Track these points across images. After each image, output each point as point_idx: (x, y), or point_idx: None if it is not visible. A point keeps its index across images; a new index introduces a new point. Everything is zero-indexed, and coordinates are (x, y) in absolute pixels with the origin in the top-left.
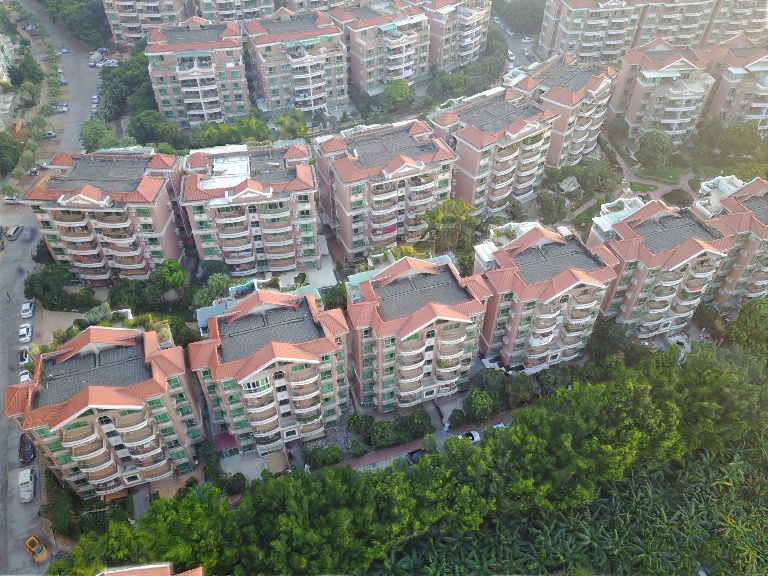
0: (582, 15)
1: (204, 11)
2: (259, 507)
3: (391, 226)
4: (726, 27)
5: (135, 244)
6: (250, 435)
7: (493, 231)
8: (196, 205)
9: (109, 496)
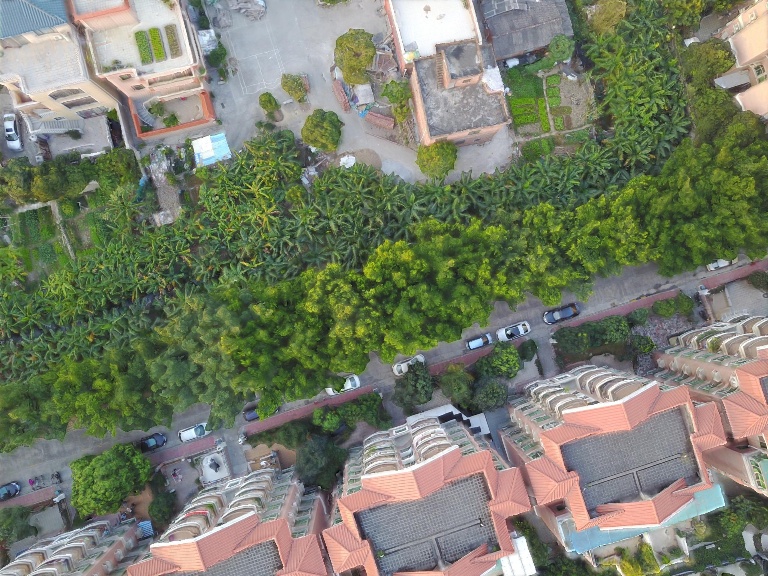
0: None
1: None
2: None
3: None
4: None
5: None
6: None
7: None
8: None
9: None
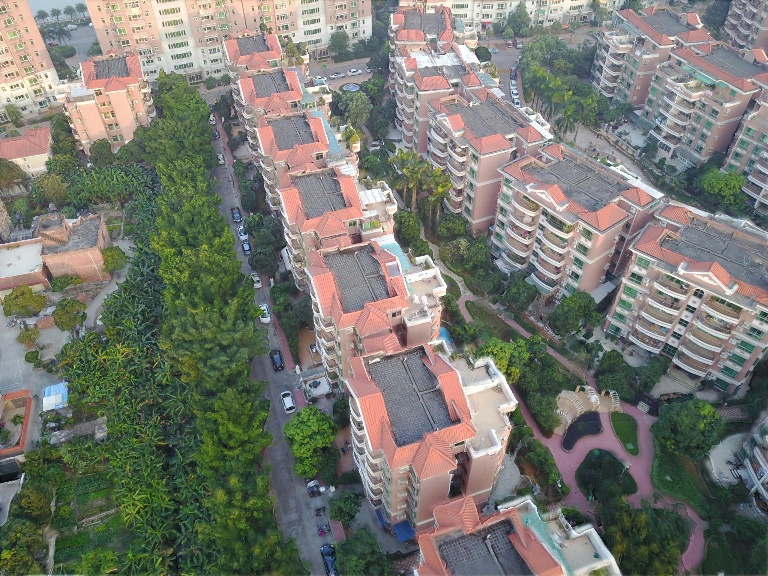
0: None
1: None
2: None
3: None
4: None
5: None
6: None
7: (381, 182)
8: None
9: None
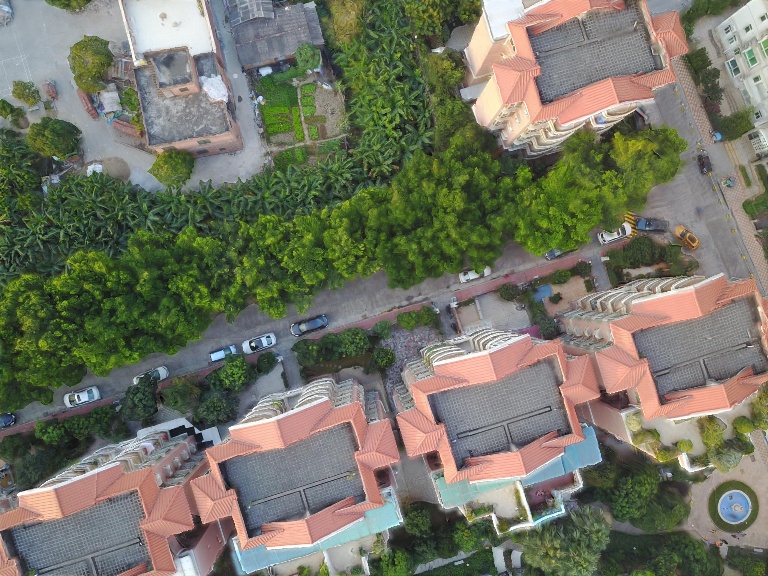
0: None
1: None
2: None
3: None
4: None
5: None
6: None
7: None
8: None
9: None
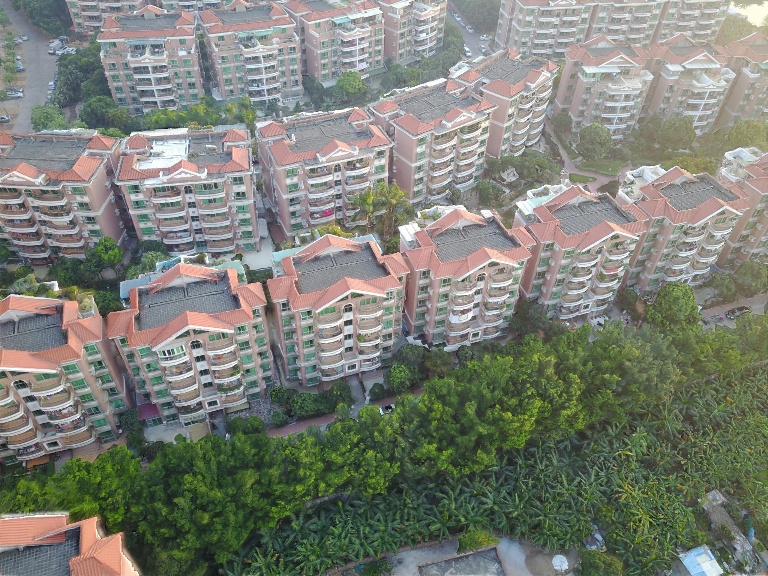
0: (533, 13)
1: (164, 1)
2: (169, 469)
3: (329, 210)
4: (675, 28)
5: (73, 223)
6: (172, 405)
7: (420, 213)
8: (131, 184)
9: (31, 462)
